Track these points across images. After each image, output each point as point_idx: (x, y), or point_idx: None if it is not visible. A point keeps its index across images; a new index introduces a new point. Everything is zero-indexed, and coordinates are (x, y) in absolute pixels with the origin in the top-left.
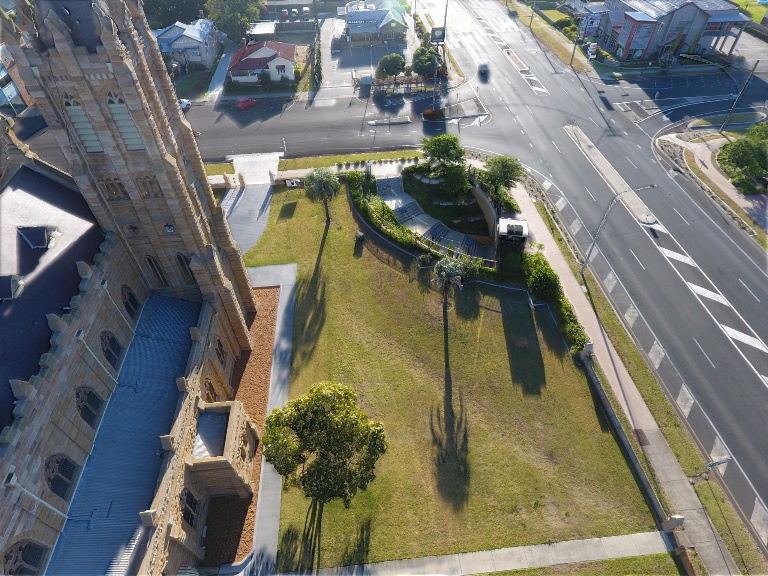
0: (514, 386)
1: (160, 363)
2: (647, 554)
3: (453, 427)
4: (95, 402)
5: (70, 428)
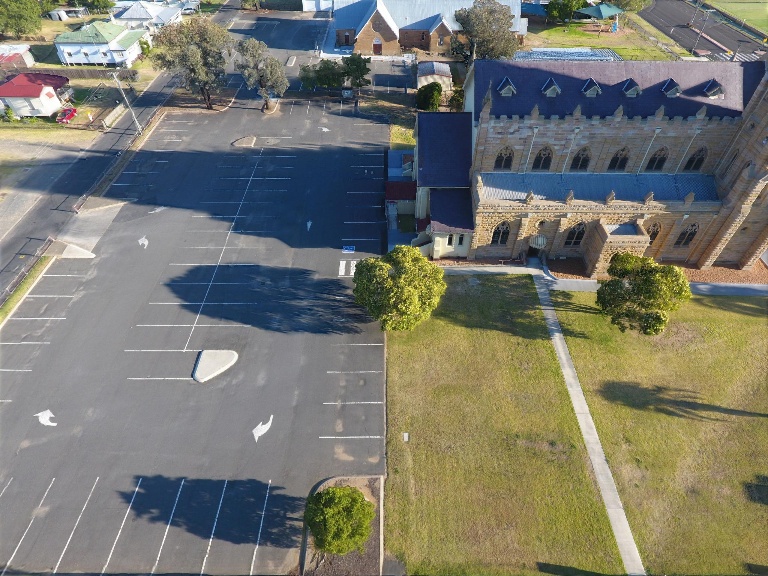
0: (767, 478)
1: (660, 193)
2: (620, 550)
3: (690, 408)
4: (622, 165)
5: (605, 152)
